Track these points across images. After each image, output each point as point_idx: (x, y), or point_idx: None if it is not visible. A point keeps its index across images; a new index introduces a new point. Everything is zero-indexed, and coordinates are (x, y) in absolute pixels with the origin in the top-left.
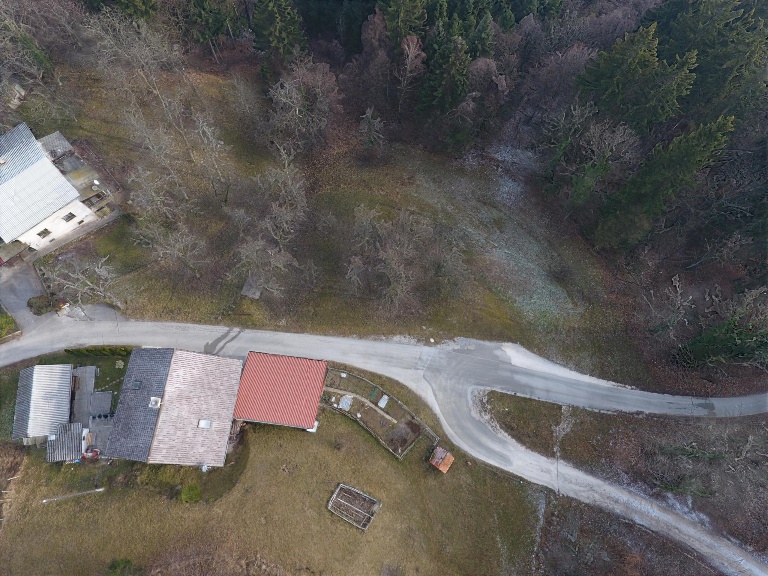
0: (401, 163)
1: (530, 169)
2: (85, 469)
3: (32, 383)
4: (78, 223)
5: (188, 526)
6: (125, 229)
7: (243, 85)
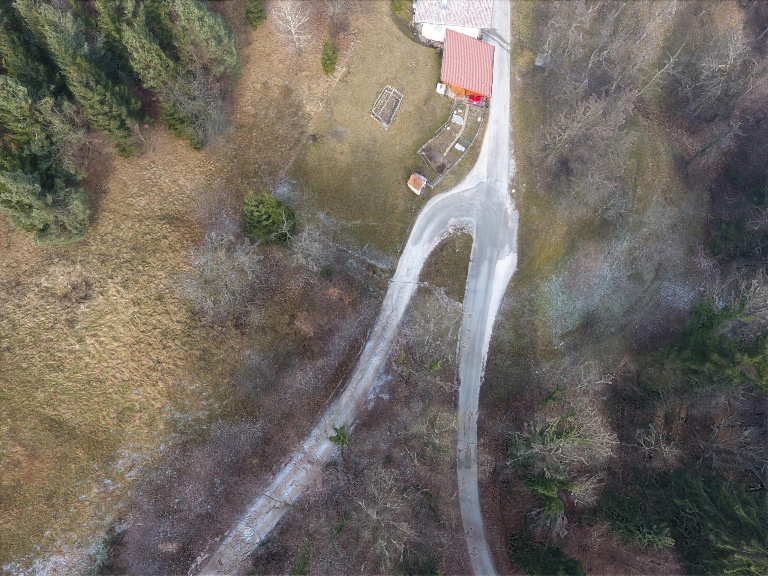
0: (687, 197)
1: None
2: None
3: None
4: None
5: (377, 4)
6: None
7: (738, 29)
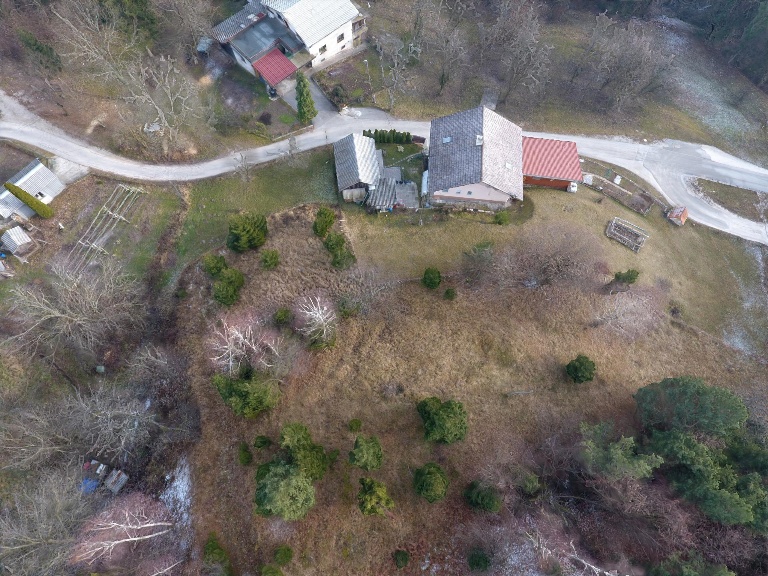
0: (576, 24)
1: (687, 30)
2: (397, 216)
3: (354, 145)
4: (341, 48)
5: (507, 238)
6: (375, 57)
7: None
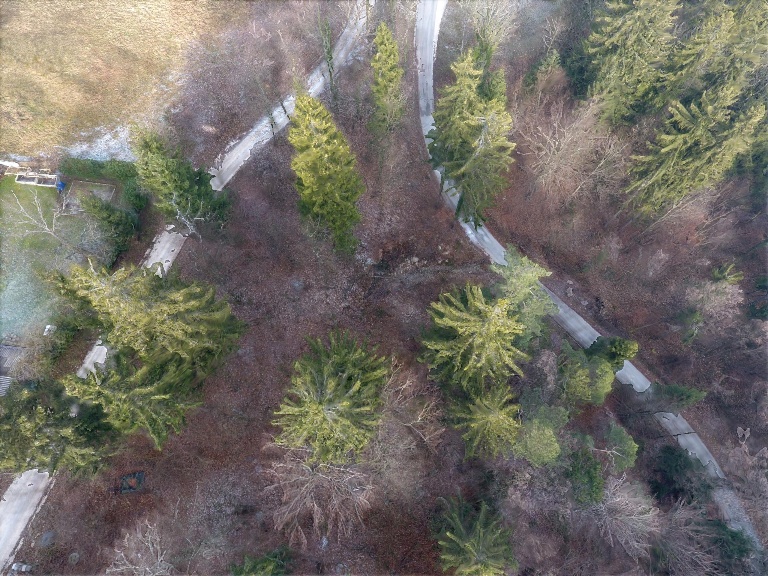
0: None
1: None
2: None
3: None
4: None
5: None
6: None
7: None
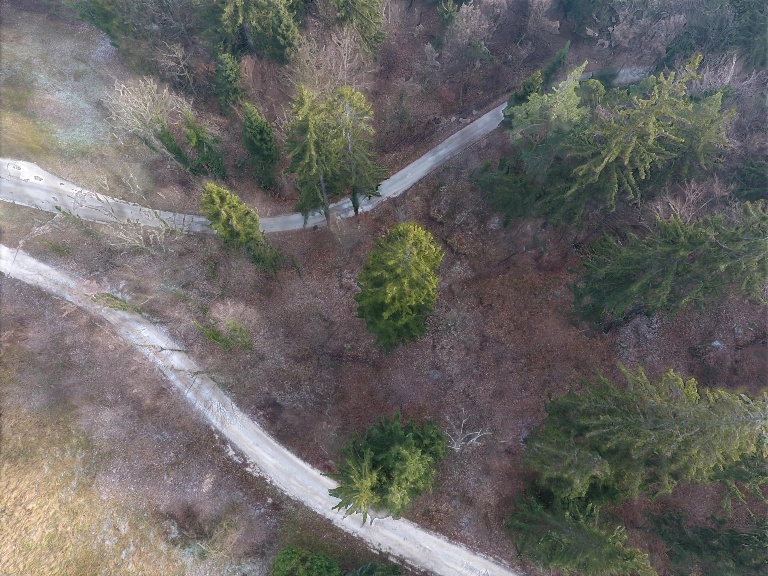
0: (20, 27)
1: None
2: None
3: None
4: None
5: None
6: None
7: None
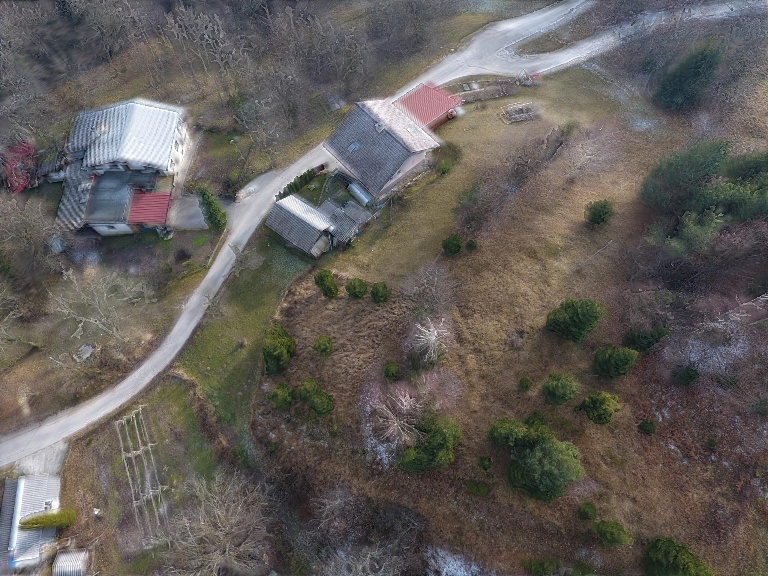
0: (319, 11)
1: None
2: (366, 233)
3: (286, 210)
4: (181, 154)
5: (460, 177)
6: (212, 140)
7: (191, 6)
